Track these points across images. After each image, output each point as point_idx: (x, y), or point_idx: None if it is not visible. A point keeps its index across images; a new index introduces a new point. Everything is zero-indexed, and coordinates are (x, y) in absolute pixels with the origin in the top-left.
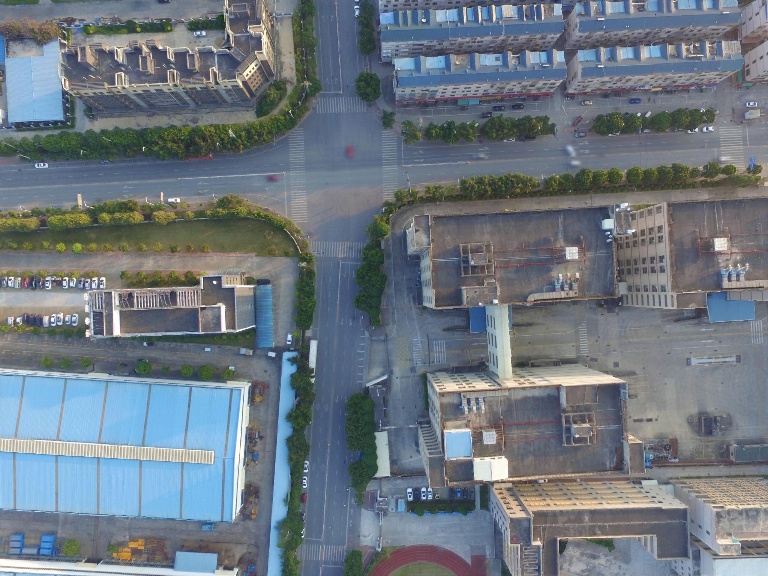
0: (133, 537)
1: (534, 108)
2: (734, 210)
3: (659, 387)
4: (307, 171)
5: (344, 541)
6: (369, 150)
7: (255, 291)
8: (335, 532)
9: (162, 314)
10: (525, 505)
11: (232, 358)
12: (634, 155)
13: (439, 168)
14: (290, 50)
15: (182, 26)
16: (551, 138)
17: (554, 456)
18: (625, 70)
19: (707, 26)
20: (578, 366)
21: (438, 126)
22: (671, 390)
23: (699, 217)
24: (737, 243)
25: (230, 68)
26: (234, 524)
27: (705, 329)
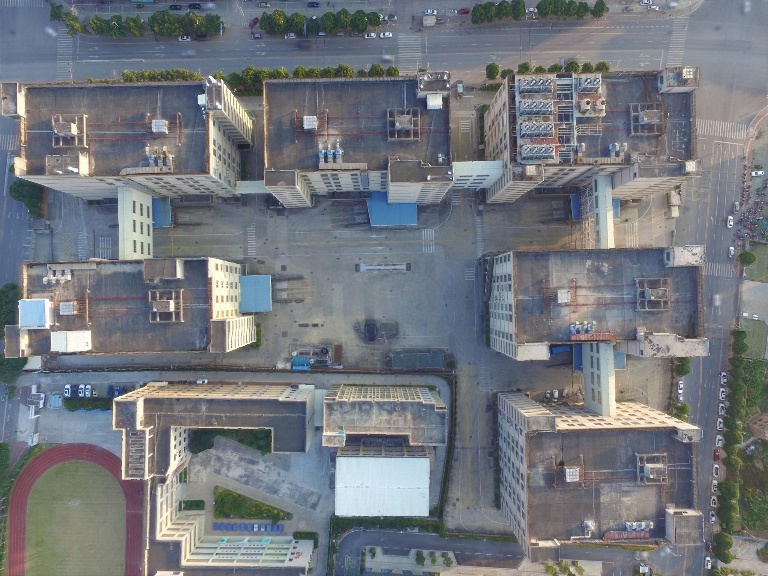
0: None
1: (211, 8)
2: (336, 92)
3: (326, 292)
4: None
5: (0, 436)
6: (44, 45)
7: None
8: None
9: None
10: (147, 394)
11: None
12: (310, 59)
13: (113, 65)
14: None
15: None
16: (228, 39)
17: (142, 333)
18: None
19: None
20: None
21: (100, 18)
22: (338, 296)
23: (300, 98)
24: (337, 125)
25: None
26: None
27: (376, 236)
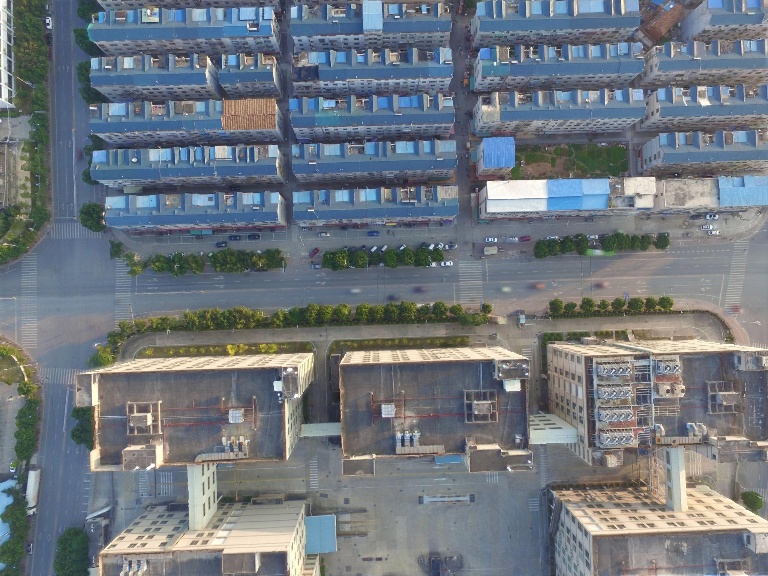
0: None
1: (271, 238)
2: (412, 372)
3: (390, 525)
4: (39, 296)
5: None
6: (103, 276)
7: None
8: None
9: None
10: None
11: None
12: (371, 288)
13: (173, 296)
14: (26, 175)
15: None
16: (287, 269)
17: None
18: (338, 214)
19: (425, 170)
20: (296, 507)
21: (161, 259)
22: (402, 529)
23: (375, 379)
24: (413, 407)
25: None
26: None
27: (439, 467)
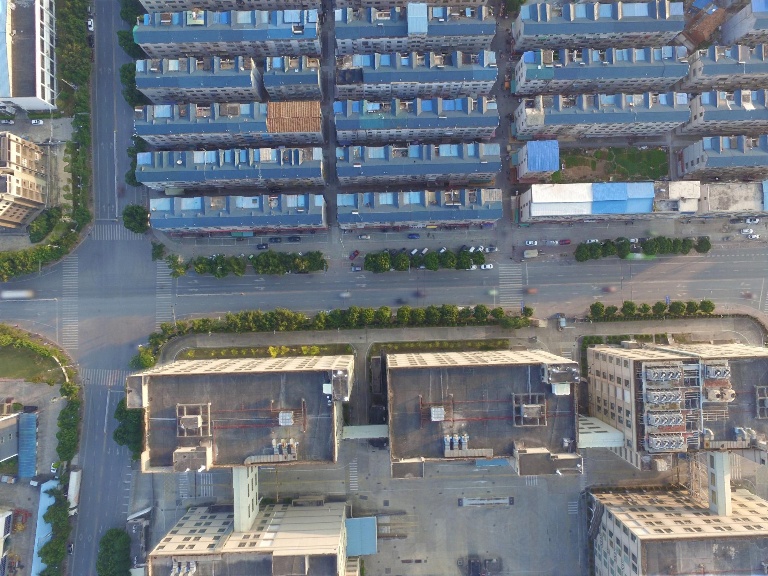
0: None
1: (311, 240)
2: (460, 376)
3: (429, 527)
4: (80, 297)
5: None
6: (143, 278)
7: (19, 419)
8: None
9: None
10: None
11: None
12: (411, 290)
13: (213, 298)
14: (68, 176)
15: None
16: (328, 271)
17: None
18: (382, 216)
19: (469, 173)
20: (337, 509)
21: (204, 261)
22: (442, 531)
23: (424, 382)
24: (462, 410)
25: None
26: None
27: (478, 469)
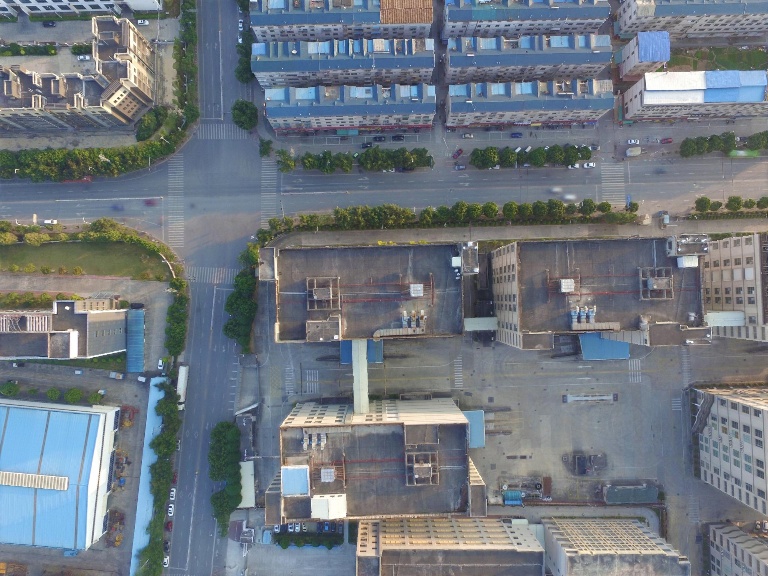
0: None
1: (415, 140)
2: (586, 251)
3: (534, 424)
4: (185, 196)
5: (209, 572)
6: (248, 177)
7: (127, 315)
8: (200, 562)
9: (14, 338)
10: (380, 543)
11: (103, 382)
12: (514, 189)
13: (318, 197)
14: (173, 76)
15: (67, 50)
16: (431, 170)
17: (397, 495)
18: (495, 106)
19: (580, 64)
20: (447, 401)
21: (313, 156)
22: (546, 427)
23: (550, 257)
24: (588, 284)
25: (97, 94)
26: (98, 551)
27: (582, 366)
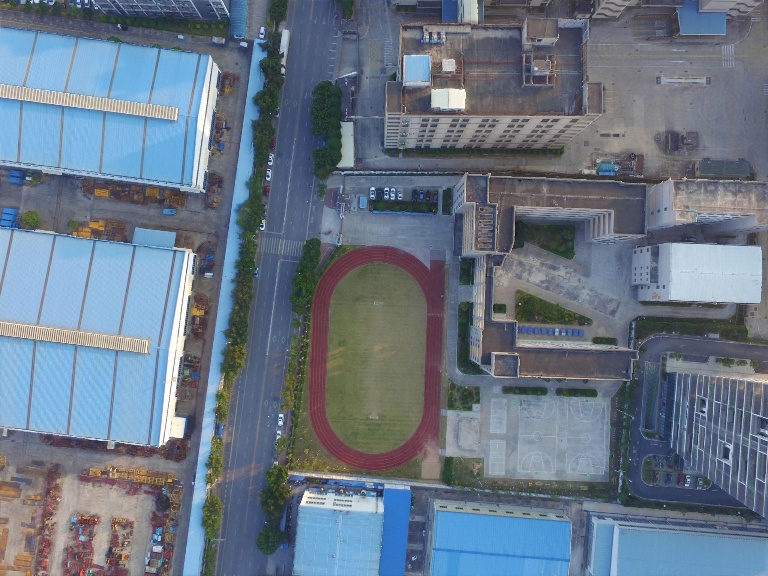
0: (94, 218)
1: None
2: None
3: (628, 104)
4: None
5: (304, 237)
6: None
7: None
8: (296, 227)
9: None
10: None
11: (204, 48)
12: None
13: None
14: None
15: None
16: None
17: (513, 98)
18: None
19: None
20: None
21: None
22: (639, 107)
23: None
24: None
25: None
26: (195, 212)
27: (676, 50)
